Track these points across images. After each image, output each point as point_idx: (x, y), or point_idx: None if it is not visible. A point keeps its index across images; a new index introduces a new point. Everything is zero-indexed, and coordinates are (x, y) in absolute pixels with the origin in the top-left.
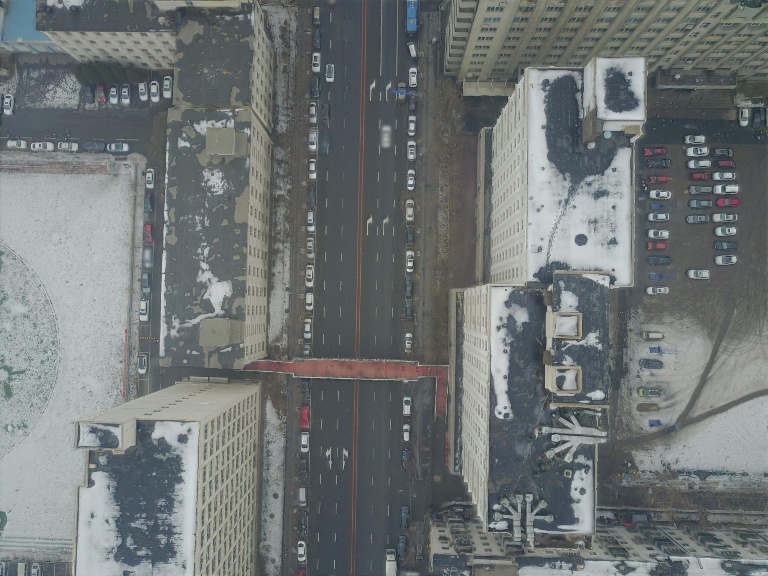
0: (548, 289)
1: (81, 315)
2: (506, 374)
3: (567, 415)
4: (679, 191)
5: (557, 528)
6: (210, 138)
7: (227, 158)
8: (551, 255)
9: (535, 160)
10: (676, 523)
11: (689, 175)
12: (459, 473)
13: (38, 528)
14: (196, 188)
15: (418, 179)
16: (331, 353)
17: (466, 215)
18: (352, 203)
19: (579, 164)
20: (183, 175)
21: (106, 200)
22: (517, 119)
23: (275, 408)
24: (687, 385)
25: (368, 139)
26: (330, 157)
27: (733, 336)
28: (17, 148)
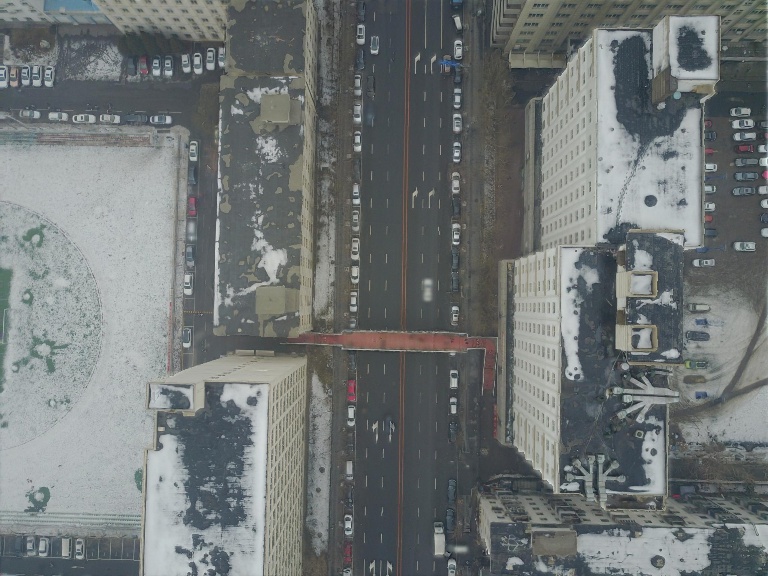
0: (619, 250)
1: (124, 289)
2: (576, 335)
3: (639, 375)
4: (725, 164)
5: (628, 489)
6: (265, 105)
7: (281, 126)
8: (621, 216)
9: (604, 121)
10: (723, 494)
11: (735, 148)
12: (510, 444)
13: (82, 503)
14: (250, 156)
15: (464, 152)
16: (377, 326)
17: (512, 188)
18: (397, 176)
19: (648, 125)
20: (236, 143)
21: (149, 173)
22: (581, 82)
23: (321, 382)
24: (733, 357)
25: (413, 112)
26: (375, 130)
27: None
28: (58, 120)
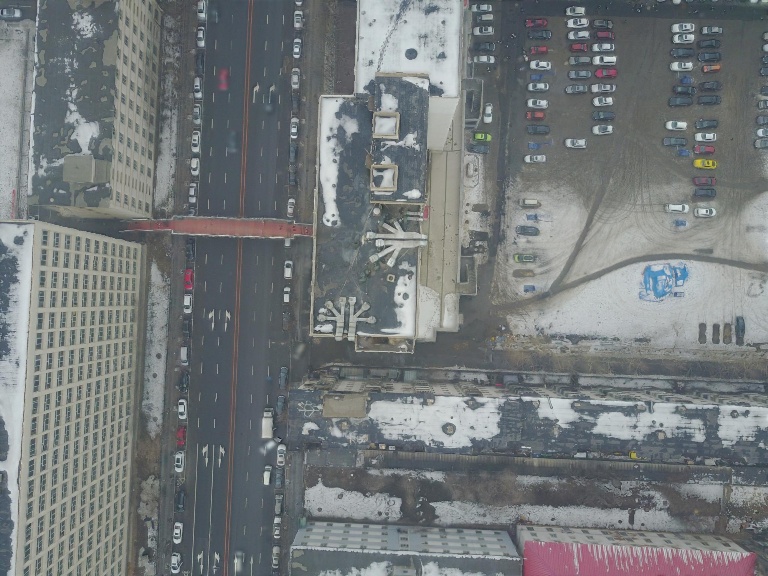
0: None
1: None
2: (335, 183)
3: (391, 221)
4: (559, 62)
5: (380, 331)
6: None
7: (97, 2)
8: (381, 68)
9: None
10: (547, 385)
11: (569, 46)
12: None
13: None
14: (66, 31)
15: (304, 48)
16: None
17: (351, 84)
18: (240, 71)
19: None
20: (53, 18)
21: None
22: None
23: (160, 270)
24: (562, 252)
25: (257, 9)
26: (219, 26)
27: (608, 205)
28: None
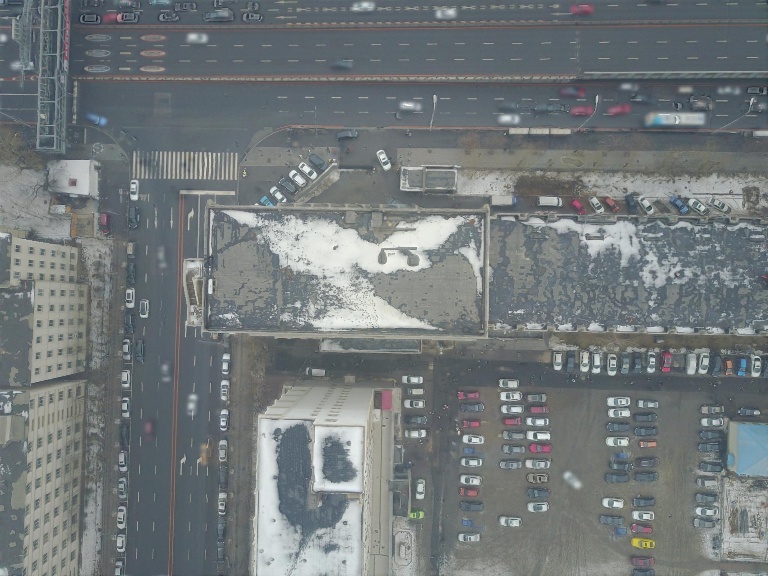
0: None
1: None
2: None
3: None
4: (493, 434)
5: None
6: None
7: None
8: None
9: (266, 512)
10: None
11: (503, 419)
12: None
13: None
14: None
15: (232, 419)
16: None
17: None
18: (166, 441)
19: (311, 516)
20: None
21: None
22: None
23: None
24: None
25: (183, 376)
26: (144, 394)
27: None
28: None
